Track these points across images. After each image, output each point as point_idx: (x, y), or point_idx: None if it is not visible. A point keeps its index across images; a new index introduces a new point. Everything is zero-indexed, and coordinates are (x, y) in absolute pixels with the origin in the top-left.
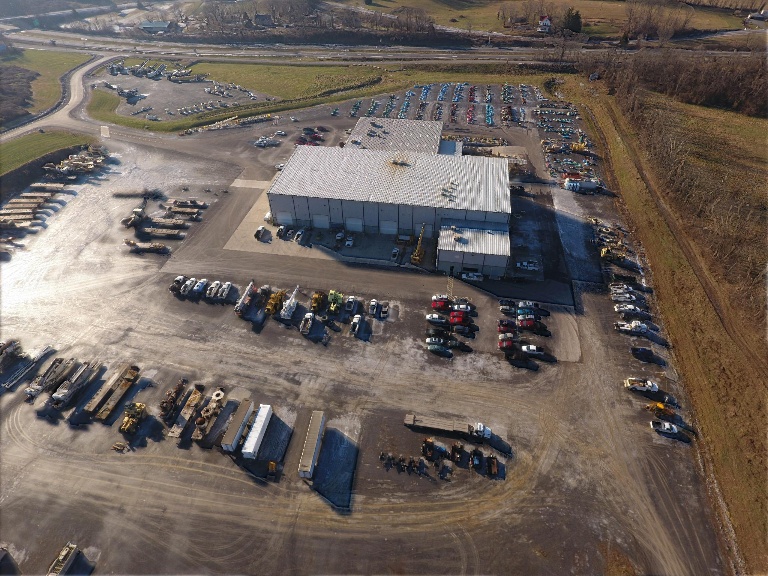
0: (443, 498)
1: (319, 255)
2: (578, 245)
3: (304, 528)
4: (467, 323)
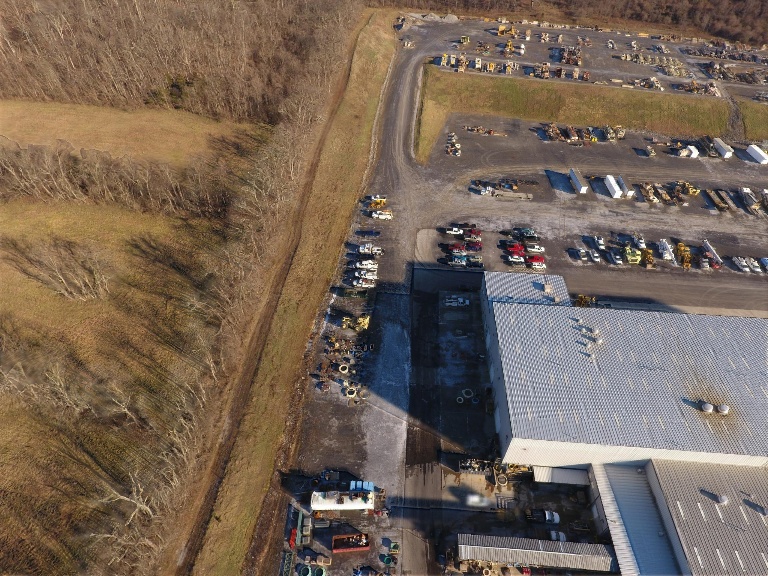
0: (501, 174)
1: (694, 310)
2: (390, 343)
3: (561, 165)
4: (509, 246)
